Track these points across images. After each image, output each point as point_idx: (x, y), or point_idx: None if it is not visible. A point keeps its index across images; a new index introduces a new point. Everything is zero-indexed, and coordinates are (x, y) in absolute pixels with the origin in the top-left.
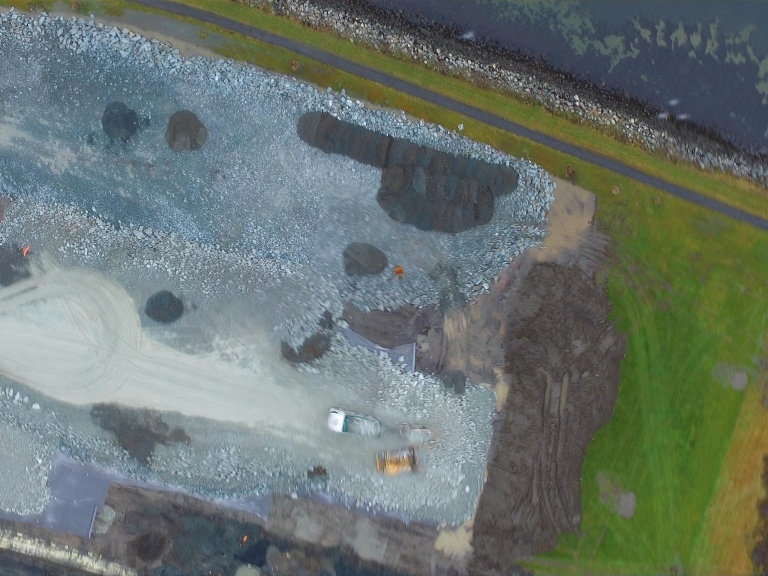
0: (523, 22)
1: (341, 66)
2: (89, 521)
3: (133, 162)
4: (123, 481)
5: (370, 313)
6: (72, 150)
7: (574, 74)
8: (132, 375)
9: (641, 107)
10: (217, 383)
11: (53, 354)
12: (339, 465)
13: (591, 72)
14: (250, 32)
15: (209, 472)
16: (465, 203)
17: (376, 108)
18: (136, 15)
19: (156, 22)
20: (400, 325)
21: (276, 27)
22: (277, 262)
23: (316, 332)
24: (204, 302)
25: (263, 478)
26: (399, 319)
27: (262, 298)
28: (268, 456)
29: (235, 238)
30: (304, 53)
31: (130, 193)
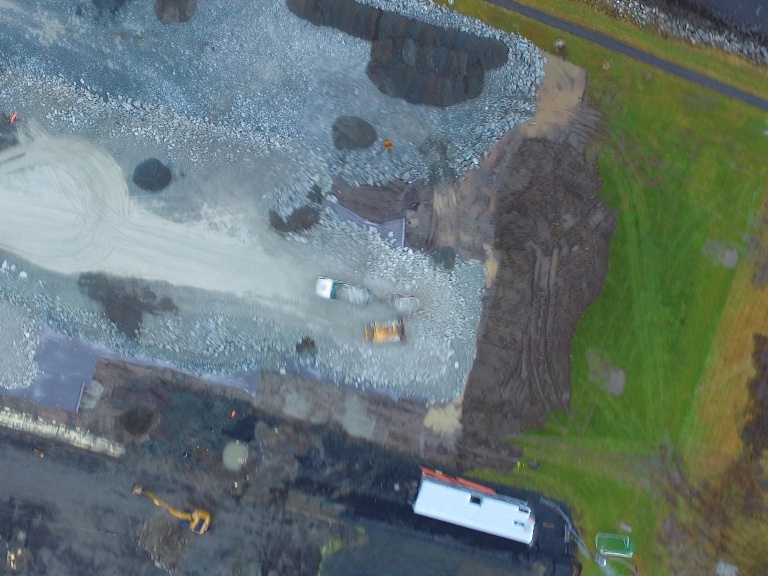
0: None
1: None
2: (77, 396)
3: (122, 34)
4: (111, 356)
5: (359, 188)
6: (60, 21)
7: None
8: (120, 244)
9: None
10: (205, 252)
11: (40, 222)
12: (327, 335)
13: None
14: None
15: (197, 345)
16: (455, 74)
17: None
18: None
19: None
20: (389, 200)
21: None
22: (266, 135)
23: (305, 204)
24: (192, 170)
25: (251, 353)
26: (388, 194)
27: (250, 167)
28: (256, 328)
29: (224, 111)
30: None
31: (119, 65)
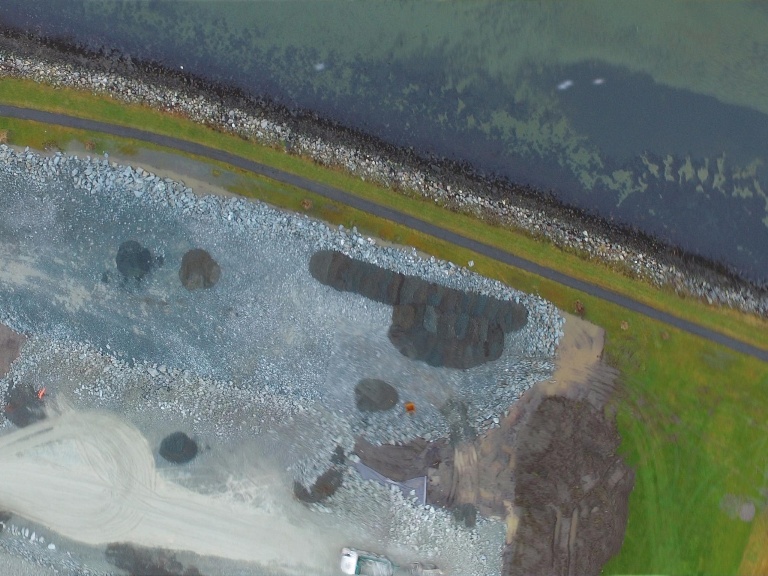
0: (532, 157)
1: (352, 204)
2: None
3: (147, 300)
4: None
5: (381, 447)
6: (86, 288)
7: (583, 209)
8: (146, 515)
9: (649, 241)
10: (231, 523)
11: (68, 494)
12: None
13: (600, 207)
14: (262, 170)
15: None
16: (476, 342)
17: (387, 245)
18: (150, 154)
19: (169, 161)
20: (411, 459)
21: (288, 166)
22: (289, 398)
23: (328, 469)
24: (218, 443)
25: None
26: (410, 453)
27: (275, 439)
28: None
29: (248, 375)
30: (316, 191)
31: (144, 331)
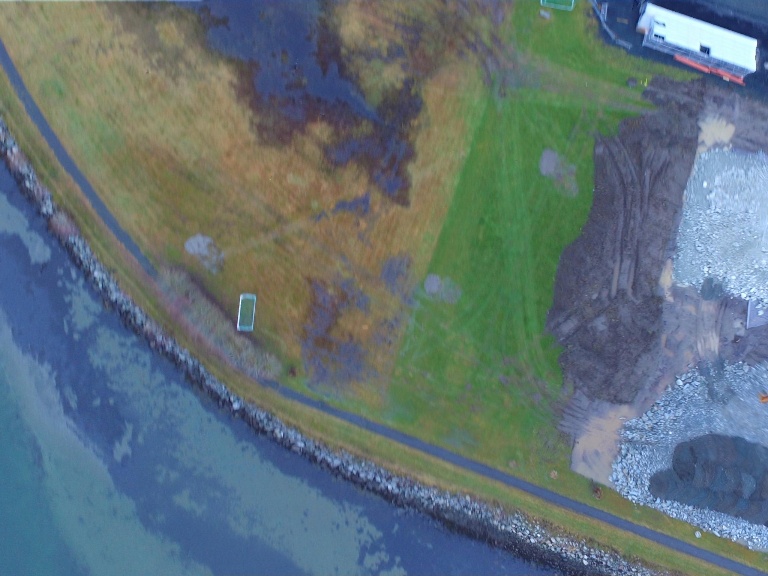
0: None
1: None
2: None
3: None
4: None
5: None
6: None
7: None
8: None
9: (522, 553)
10: None
11: None
12: None
13: None
14: None
15: None
16: (707, 465)
17: None
18: None
19: None
20: (761, 345)
21: None
22: None
23: None
24: None
25: None
26: (762, 351)
27: None
28: None
29: None
30: None
31: None
